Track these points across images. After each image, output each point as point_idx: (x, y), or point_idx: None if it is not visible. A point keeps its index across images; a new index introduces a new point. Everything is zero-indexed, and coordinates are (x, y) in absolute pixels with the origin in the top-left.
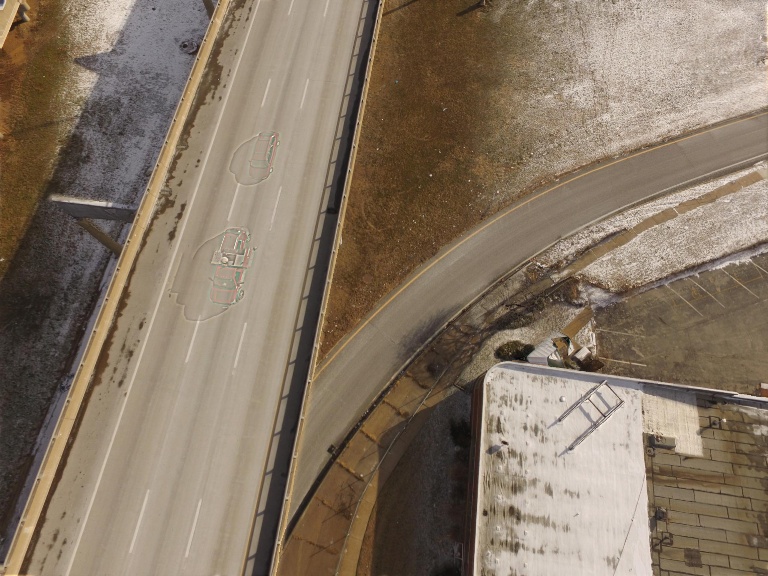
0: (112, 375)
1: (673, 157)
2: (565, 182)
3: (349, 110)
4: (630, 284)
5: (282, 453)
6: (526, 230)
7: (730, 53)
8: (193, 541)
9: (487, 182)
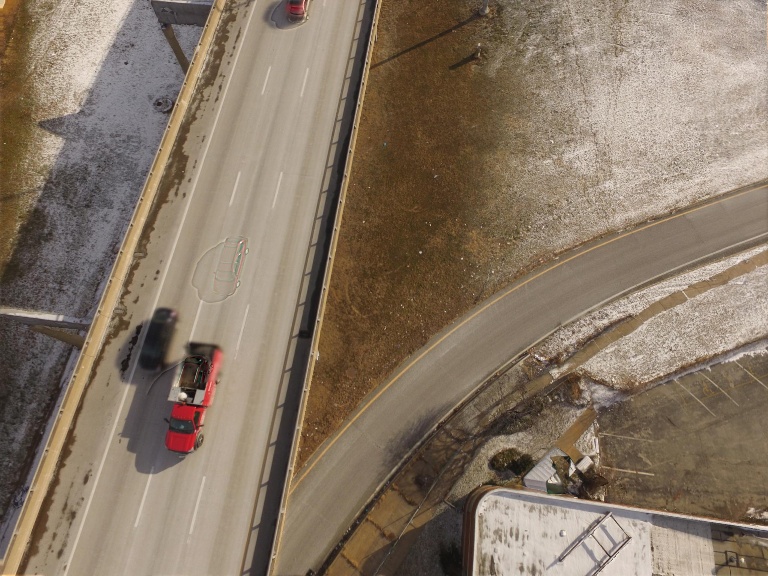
0: (51, 543)
1: (681, 231)
2: (565, 260)
3: (326, 210)
4: (636, 380)
5: None
6: (523, 316)
7: (741, 111)
8: None
9: (481, 260)
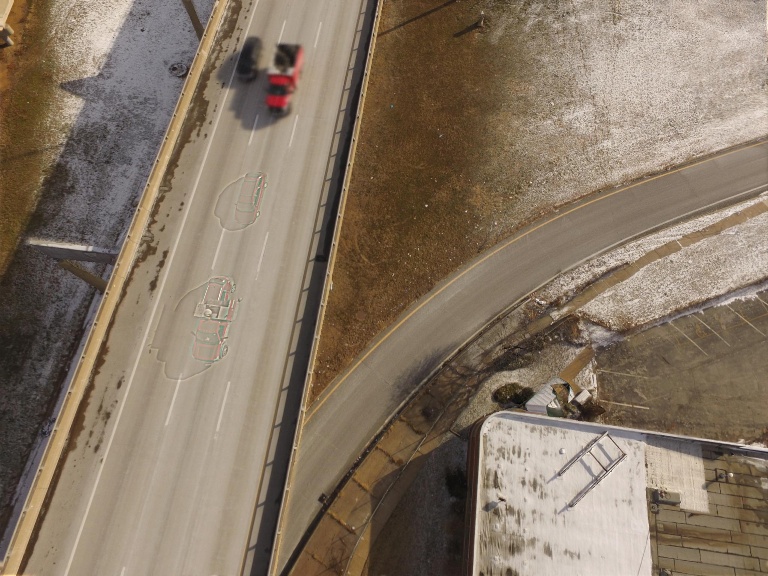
0: (88, 439)
1: (676, 186)
2: (565, 213)
3: (340, 149)
4: (632, 322)
5: (266, 526)
6: (525, 264)
7: (734, 76)
8: None
9: (484, 213)
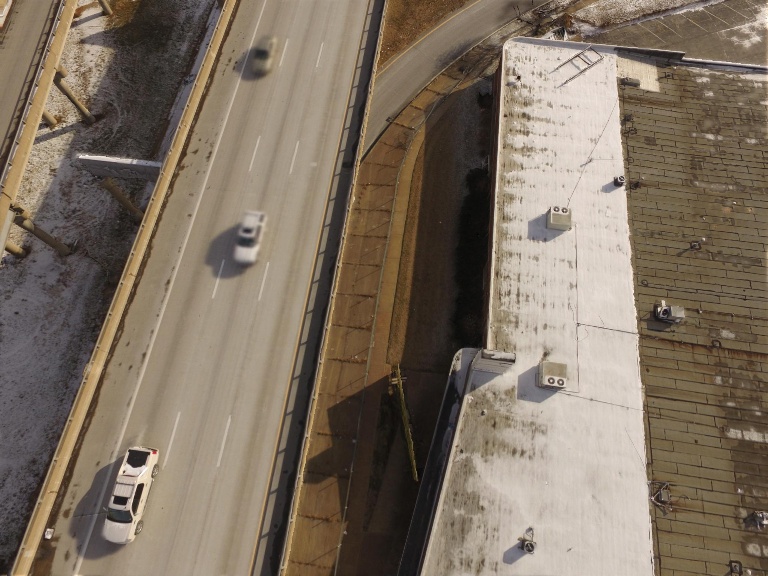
0: None
1: None
2: None
3: None
4: (611, 21)
5: (374, 22)
6: None
7: None
8: (320, 60)
9: None
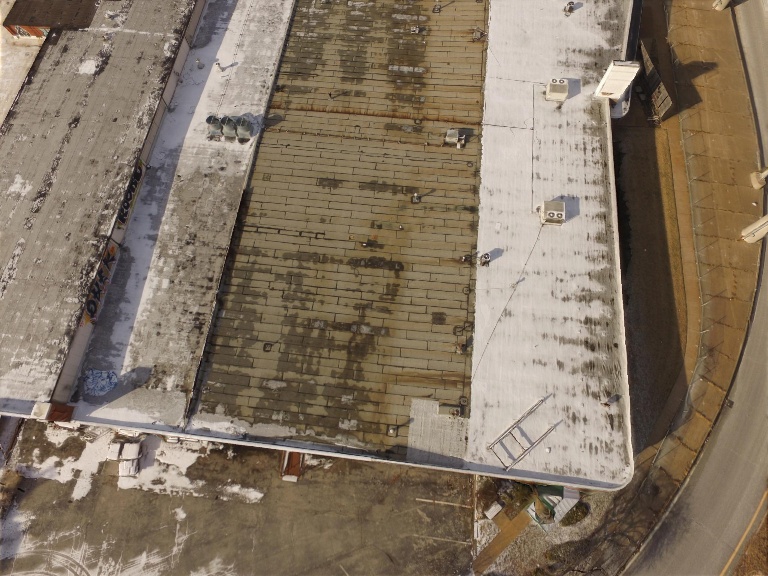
0: None
1: None
2: None
3: None
4: None
5: None
6: None
7: None
8: None
9: None
